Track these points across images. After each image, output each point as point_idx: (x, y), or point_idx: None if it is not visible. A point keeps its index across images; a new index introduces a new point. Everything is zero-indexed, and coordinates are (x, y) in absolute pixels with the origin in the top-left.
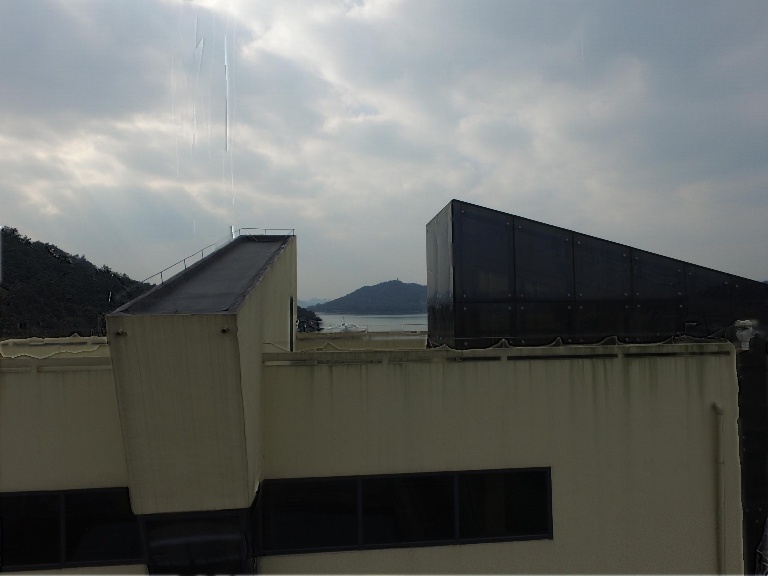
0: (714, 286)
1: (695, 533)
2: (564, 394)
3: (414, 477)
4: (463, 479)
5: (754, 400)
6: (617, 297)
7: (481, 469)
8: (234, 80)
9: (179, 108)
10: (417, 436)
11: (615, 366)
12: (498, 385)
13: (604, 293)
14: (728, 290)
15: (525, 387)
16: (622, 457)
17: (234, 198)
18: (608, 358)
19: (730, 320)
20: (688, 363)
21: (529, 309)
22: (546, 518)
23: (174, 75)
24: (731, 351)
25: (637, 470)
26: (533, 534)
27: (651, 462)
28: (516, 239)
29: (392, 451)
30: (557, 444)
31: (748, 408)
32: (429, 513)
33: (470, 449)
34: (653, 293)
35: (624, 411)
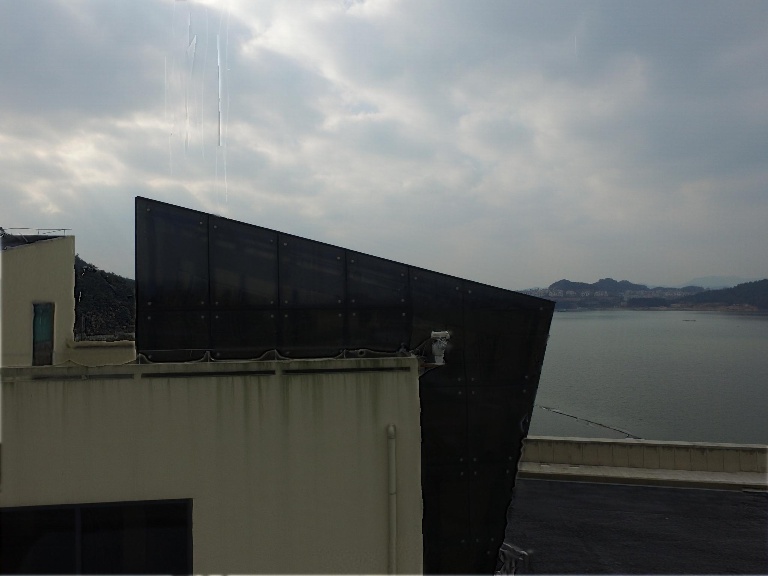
0: (449, 292)
1: (365, 572)
2: (210, 416)
3: (26, 511)
4: (87, 513)
5: (500, 417)
6: (330, 304)
7: (108, 501)
8: (227, 78)
9: (172, 106)
10: (34, 464)
11: (272, 384)
12: (131, 406)
13: (315, 300)
14: (460, 296)
15: (163, 408)
16: (279, 487)
17: (227, 197)
18: (264, 375)
19: (462, 329)
20: (360, 380)
21: (226, 318)
22: (184, 556)
23: (167, 73)
24: (412, 367)
25: (297, 501)
26: (170, 574)
27: (314, 492)
28: (212, 240)
29: (0, 482)
30: (203, 472)
31: (494, 426)
32: (51, 551)
33: (99, 478)
34: (374, 300)
35: (282, 435)
